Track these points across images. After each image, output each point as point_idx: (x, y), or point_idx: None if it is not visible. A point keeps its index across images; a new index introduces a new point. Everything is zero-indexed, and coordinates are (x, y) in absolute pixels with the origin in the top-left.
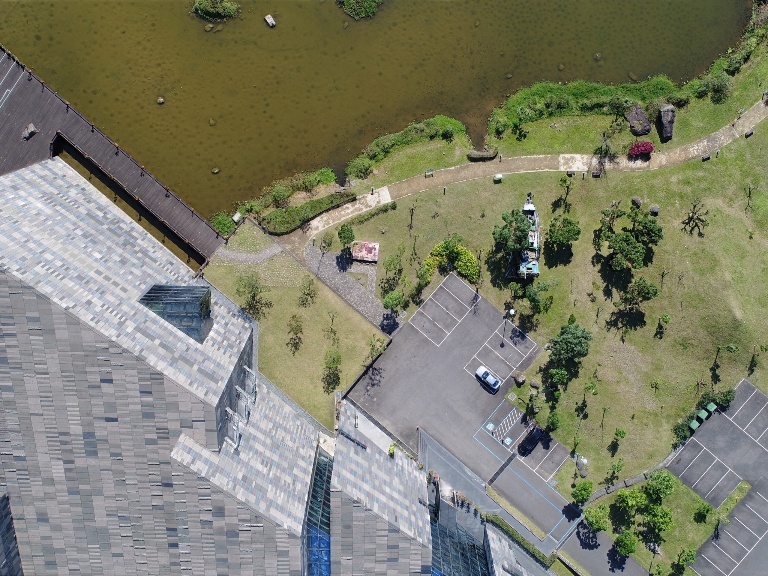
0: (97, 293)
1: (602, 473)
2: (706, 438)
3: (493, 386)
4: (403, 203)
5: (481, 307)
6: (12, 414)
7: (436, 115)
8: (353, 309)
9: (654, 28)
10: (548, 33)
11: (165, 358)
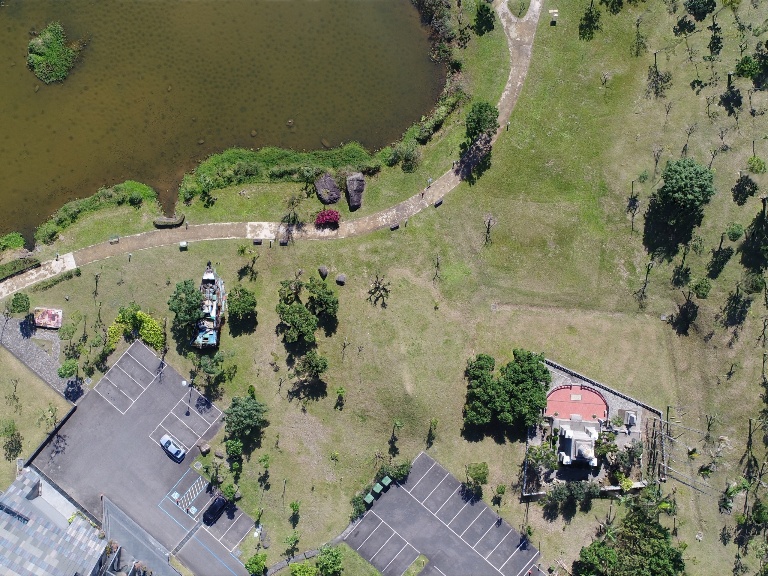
0: None
1: (284, 544)
2: (384, 511)
3: (175, 455)
4: (88, 270)
5: (167, 375)
6: None
7: (126, 180)
8: (36, 376)
9: (348, 95)
10: (241, 99)
11: None
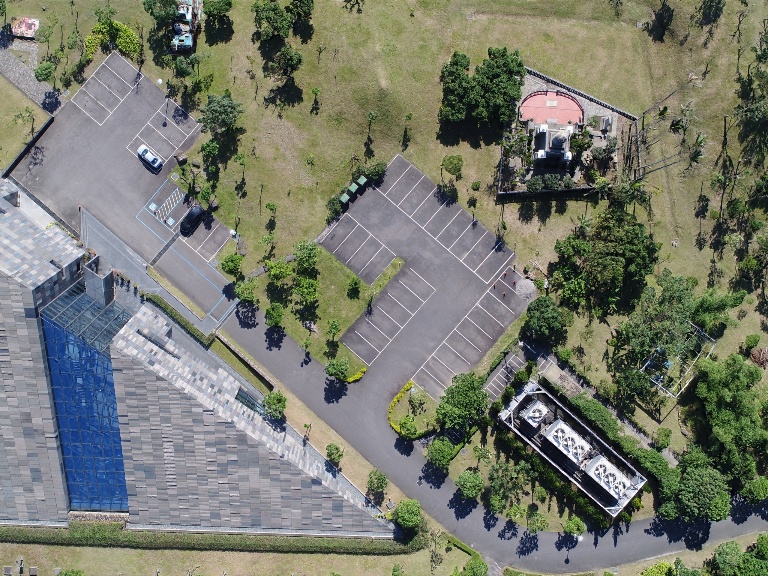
0: None
1: (261, 252)
2: (360, 214)
3: (152, 164)
4: None
5: (144, 86)
6: None
7: None
8: (14, 86)
9: None
10: None
11: None
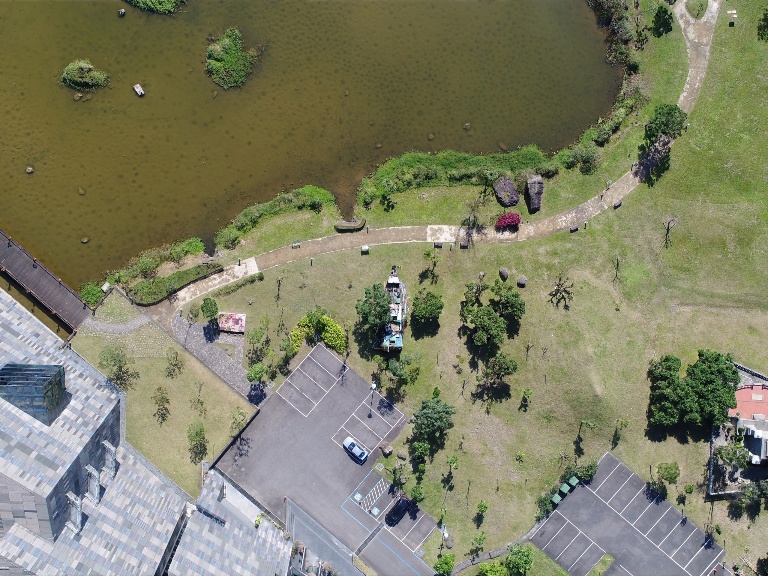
0: None
1: (468, 544)
2: (570, 511)
3: (359, 457)
4: (270, 274)
5: (349, 378)
6: None
7: (305, 185)
8: (220, 380)
9: (524, 97)
10: (418, 102)
11: None
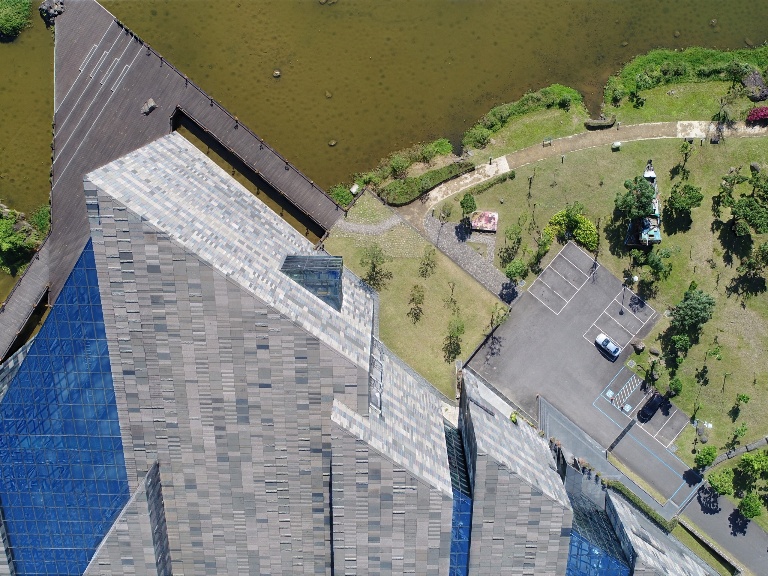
0: (246, 261)
1: (723, 438)
2: None
3: (613, 353)
4: (521, 172)
5: (600, 275)
6: (167, 381)
7: (552, 84)
8: (473, 279)
9: None
10: None
11: (316, 324)
